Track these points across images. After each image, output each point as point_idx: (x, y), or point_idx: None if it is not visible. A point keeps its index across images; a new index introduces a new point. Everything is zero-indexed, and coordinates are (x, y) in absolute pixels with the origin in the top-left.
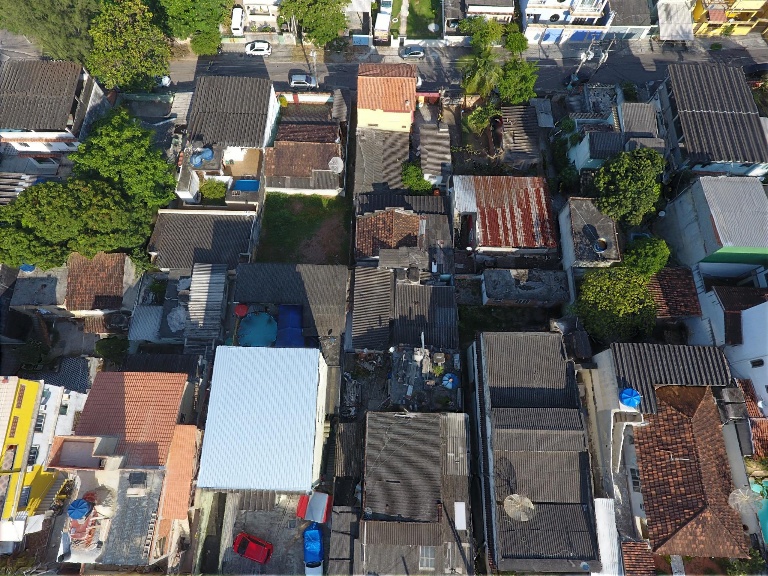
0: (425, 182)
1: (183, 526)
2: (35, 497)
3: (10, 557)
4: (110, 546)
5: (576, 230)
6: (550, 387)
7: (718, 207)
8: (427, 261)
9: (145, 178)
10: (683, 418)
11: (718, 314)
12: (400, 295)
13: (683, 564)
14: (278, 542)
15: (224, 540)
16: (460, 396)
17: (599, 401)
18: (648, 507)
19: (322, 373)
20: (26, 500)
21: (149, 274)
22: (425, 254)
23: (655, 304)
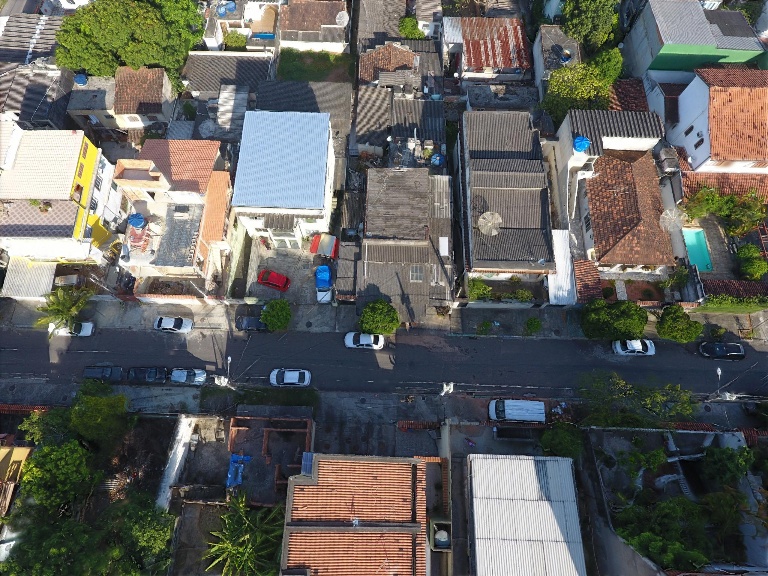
0: (419, 31)
1: (216, 264)
2: (95, 239)
3: (75, 286)
4: (161, 254)
5: (546, 48)
6: (519, 150)
7: (662, 18)
8: (420, 80)
9: (181, 6)
10: (625, 164)
11: (660, 102)
12: (397, 108)
13: (625, 287)
14: (294, 279)
15: (250, 275)
16: (446, 173)
17: (559, 165)
18: (595, 232)
19: (331, 148)
20: (89, 237)
21: (181, 101)
22: (418, 75)
23: (608, 94)
